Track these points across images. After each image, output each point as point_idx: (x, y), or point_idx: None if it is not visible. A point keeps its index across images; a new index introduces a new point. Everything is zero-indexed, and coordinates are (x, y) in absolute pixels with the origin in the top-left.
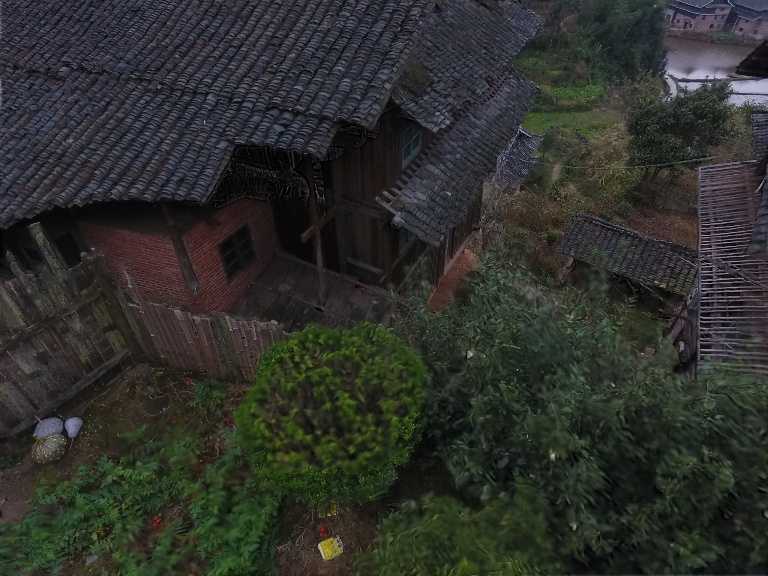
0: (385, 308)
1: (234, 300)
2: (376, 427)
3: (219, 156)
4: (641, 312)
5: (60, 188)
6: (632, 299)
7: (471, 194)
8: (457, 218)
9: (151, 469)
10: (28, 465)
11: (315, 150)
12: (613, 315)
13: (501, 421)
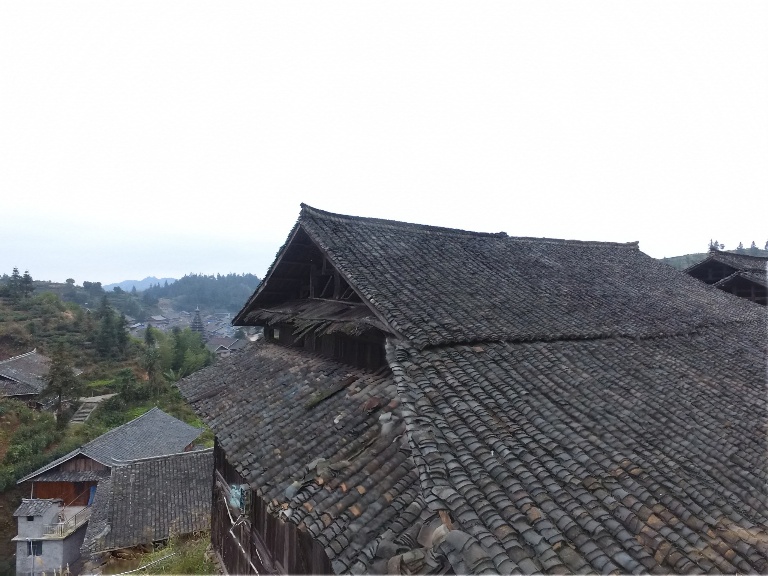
0: None
1: None
2: None
3: None
4: None
5: None
6: None
7: None
8: None
9: None
10: None
11: None
12: None
13: None
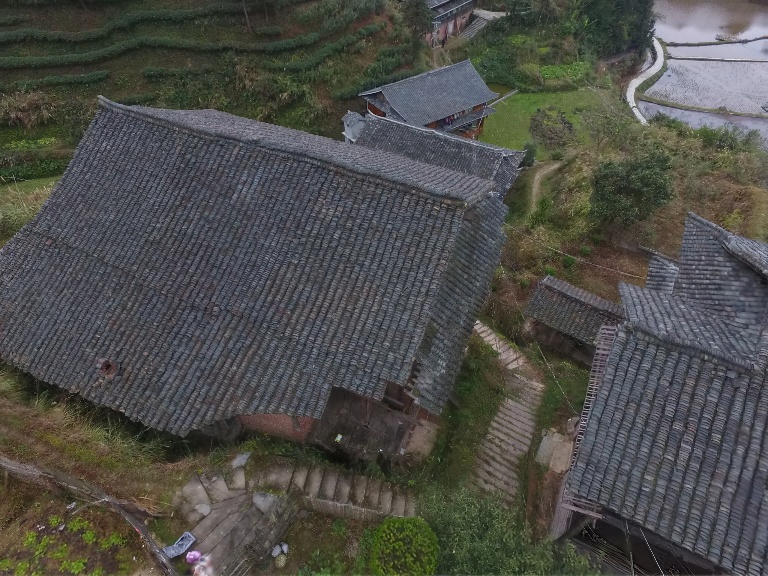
0: (406, 427)
1: (314, 421)
2: (421, 568)
3: (326, 393)
4: (580, 370)
5: (237, 402)
6: (518, 508)
7: (457, 368)
8: (449, 390)
9: (329, 572)
10: (272, 568)
11: (378, 399)
12: (560, 373)
13: (464, 575)
